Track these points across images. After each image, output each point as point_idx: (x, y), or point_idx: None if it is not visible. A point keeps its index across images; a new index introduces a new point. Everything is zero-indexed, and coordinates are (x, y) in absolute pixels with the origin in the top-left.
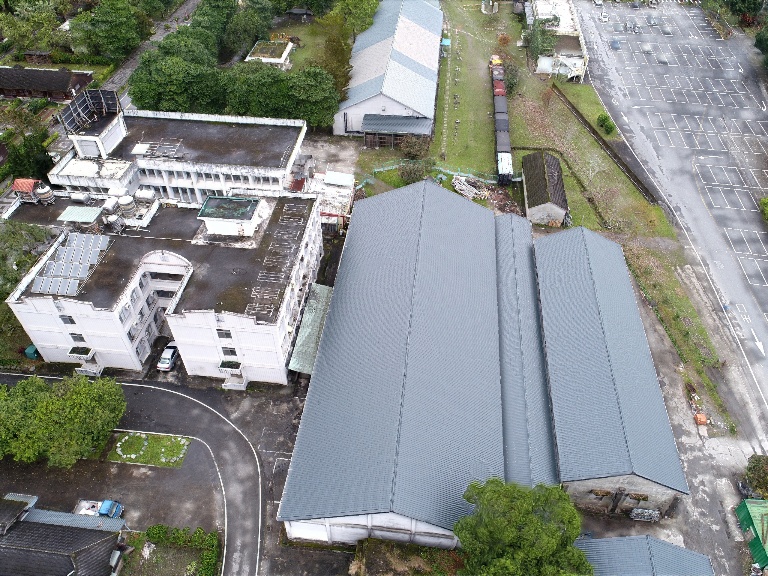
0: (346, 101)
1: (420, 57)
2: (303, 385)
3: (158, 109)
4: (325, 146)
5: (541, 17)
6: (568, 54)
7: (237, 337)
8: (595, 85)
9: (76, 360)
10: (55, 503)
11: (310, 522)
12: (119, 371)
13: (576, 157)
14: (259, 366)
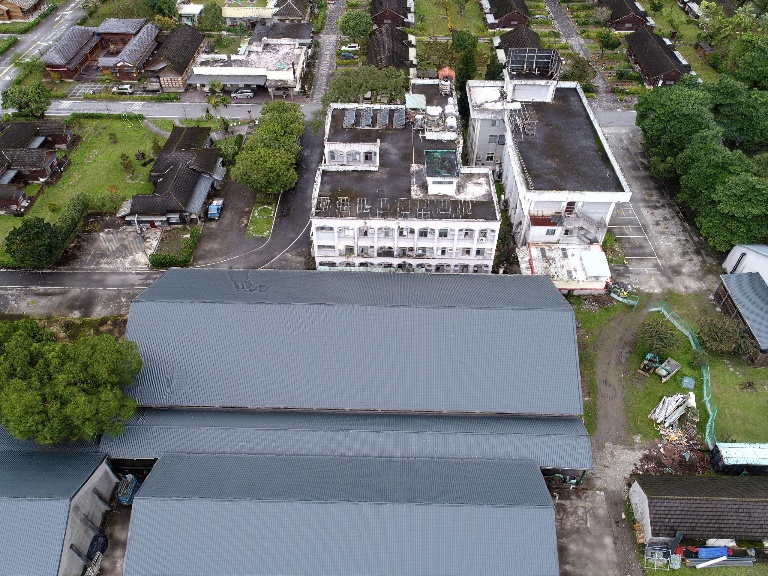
0: (767, 247)
1: None
2: None
3: None
4: (692, 262)
5: None
6: None
7: None
8: None
9: None
10: (227, 193)
11: None
12: None
13: None
14: None
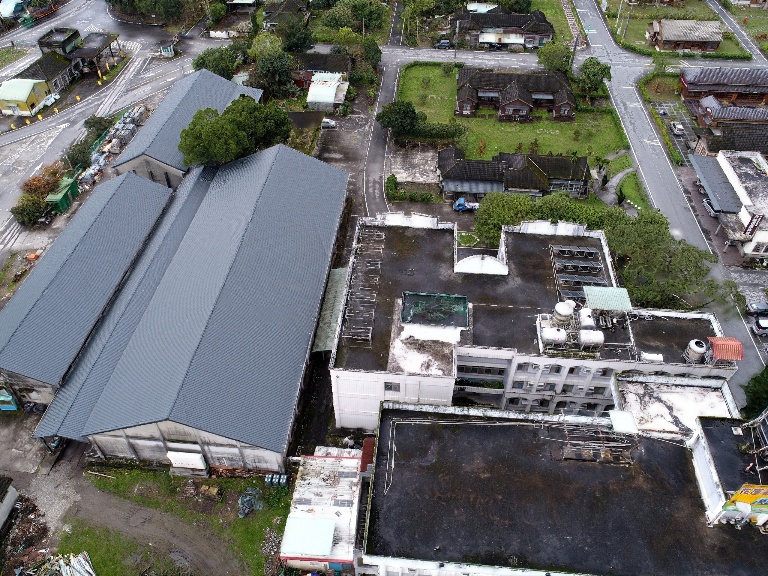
0: None
1: None
2: None
3: None
4: None
5: None
6: None
7: None
8: None
9: None
10: None
11: None
12: None
13: None
14: None
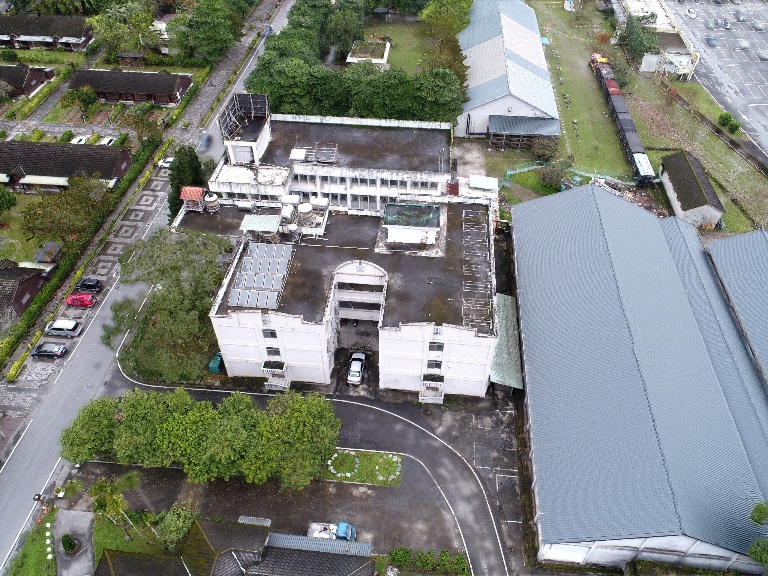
0: (468, 102)
1: (530, 56)
2: (501, 397)
3: (277, 112)
4: None
5: (634, 14)
6: (675, 52)
7: (449, 350)
8: (703, 83)
9: (262, 374)
10: (282, 525)
11: (575, 544)
12: (307, 385)
13: (706, 157)
14: (461, 379)
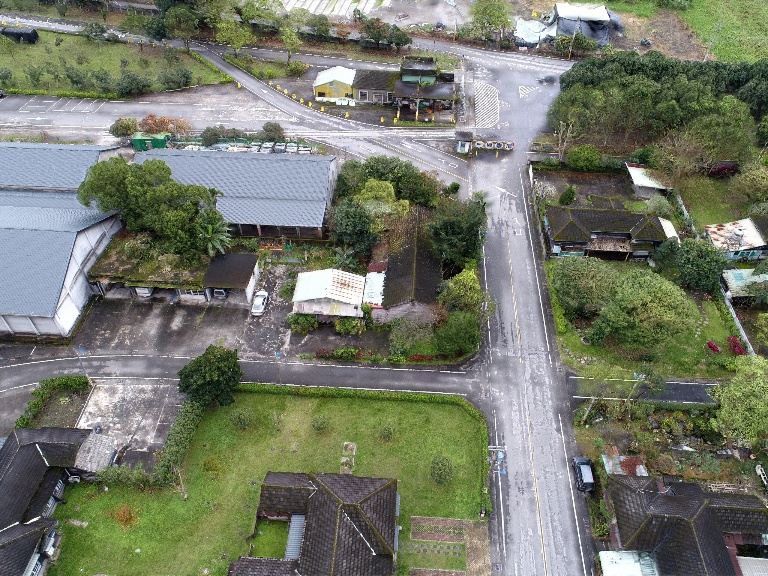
0: None
1: None
2: None
3: None
4: None
5: None
6: None
7: None
8: None
9: None
10: None
11: (62, 300)
12: None
13: None
14: None
